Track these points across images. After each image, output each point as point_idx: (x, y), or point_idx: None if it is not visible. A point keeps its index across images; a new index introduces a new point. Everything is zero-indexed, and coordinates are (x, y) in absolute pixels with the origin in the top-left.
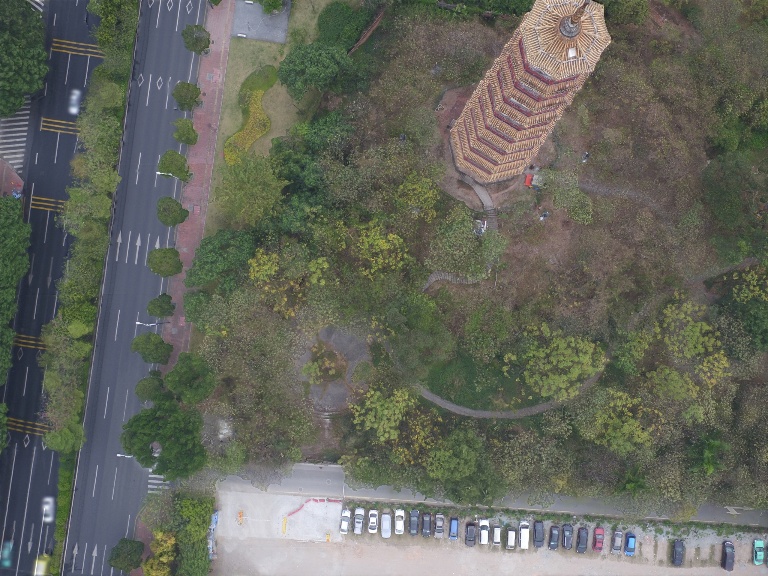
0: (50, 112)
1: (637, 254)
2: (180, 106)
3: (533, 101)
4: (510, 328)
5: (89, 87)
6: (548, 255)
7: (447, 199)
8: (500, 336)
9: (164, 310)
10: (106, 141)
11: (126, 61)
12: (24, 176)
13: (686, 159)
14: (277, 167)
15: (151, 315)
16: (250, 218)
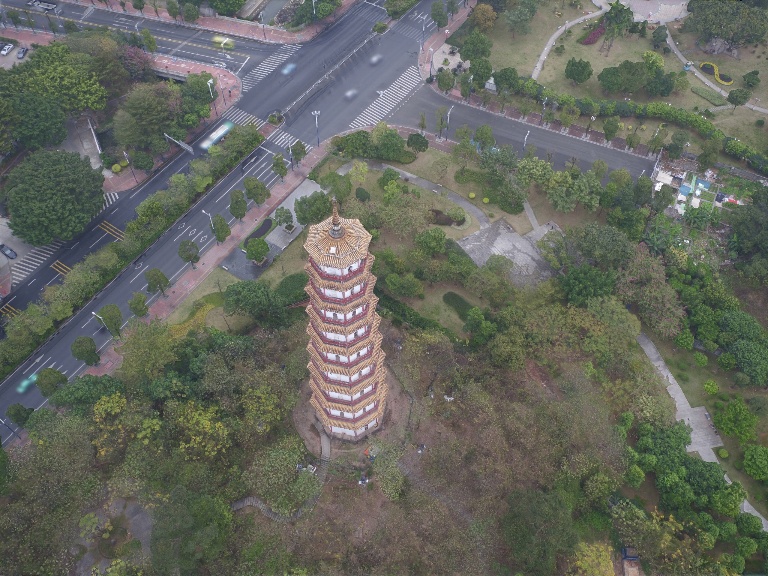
0: (66, 259)
1: (423, 547)
2: (148, 287)
3: (320, 301)
4: (279, 568)
5: (99, 250)
6: (356, 526)
7: (292, 431)
8: (267, 572)
9: (20, 417)
10: (82, 286)
11: (135, 247)
12: (14, 289)
13: (505, 486)
14: (178, 346)
15: (7, 415)
16: (130, 370)
